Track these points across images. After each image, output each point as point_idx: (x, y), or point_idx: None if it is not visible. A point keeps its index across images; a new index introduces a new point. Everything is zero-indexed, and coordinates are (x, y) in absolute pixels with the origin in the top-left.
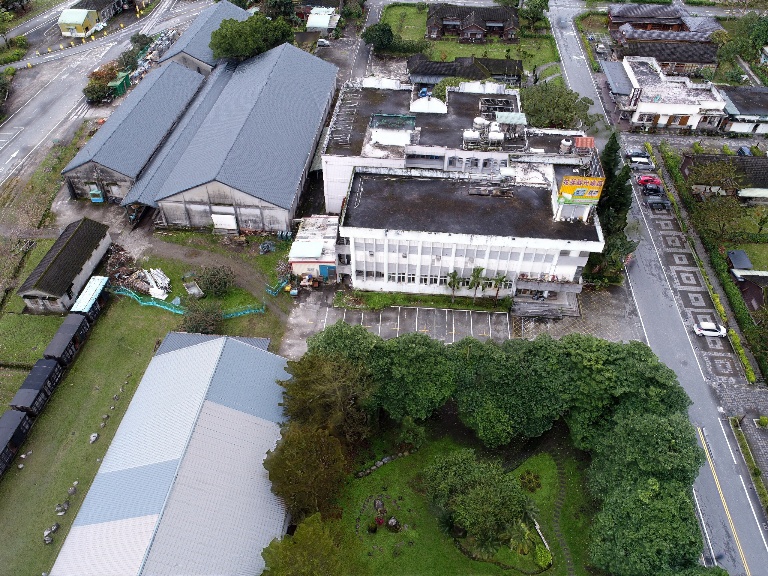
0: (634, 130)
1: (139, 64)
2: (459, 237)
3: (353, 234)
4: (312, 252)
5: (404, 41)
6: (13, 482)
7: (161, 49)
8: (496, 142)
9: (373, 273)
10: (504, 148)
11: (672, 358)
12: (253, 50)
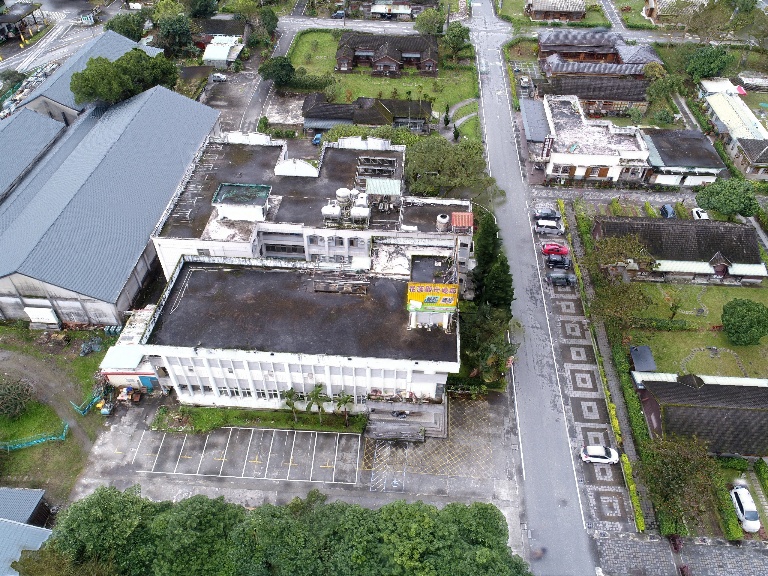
0: (548, 183)
1: (4, 106)
2: (284, 356)
3: (157, 352)
4: (128, 361)
5: (305, 77)
6: None
7: (33, 87)
8: (360, 219)
9: (200, 387)
10: (374, 223)
11: (549, 496)
12: (125, 92)
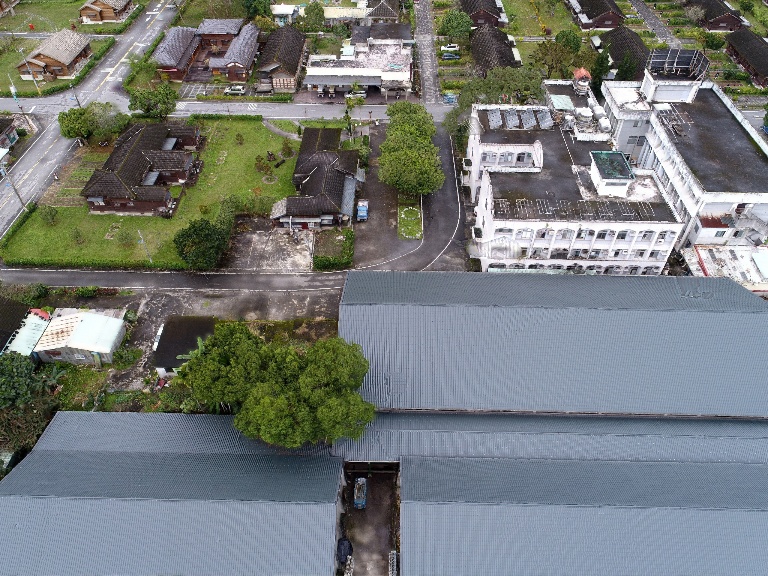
0: None
1: None
2: None
3: None
4: None
5: (226, 218)
6: None
7: None
8: None
9: None
10: None
11: None
12: None
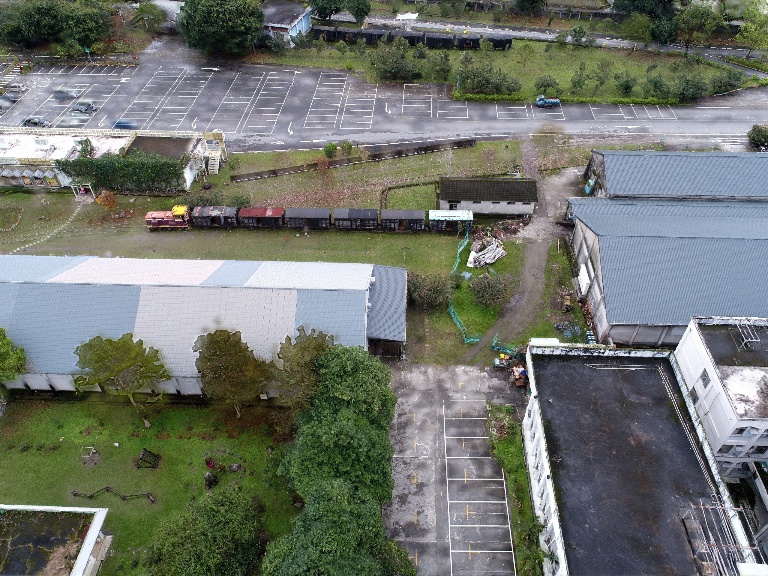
0: None
1: None
2: None
3: None
4: None
5: None
6: (287, 236)
7: None
8: None
9: None
10: None
11: None
12: None
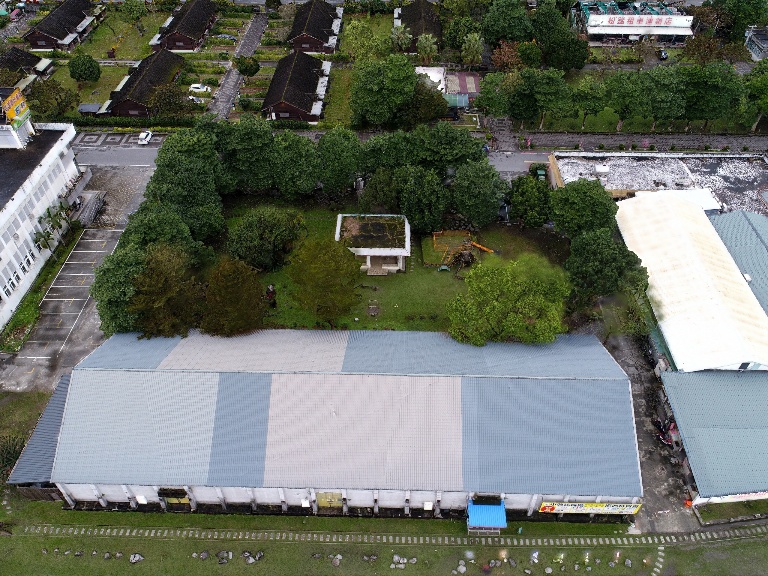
0: None
1: None
2: (17, 196)
3: None
4: None
5: None
6: None
7: None
8: None
9: None
10: None
11: None
12: None
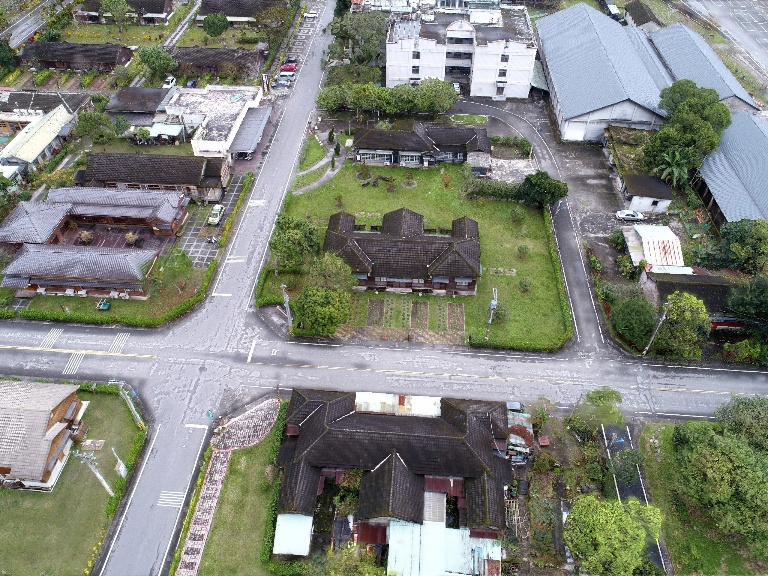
0: None
1: None
2: None
3: None
4: None
5: (504, 181)
6: None
7: None
8: None
9: None
10: None
11: None
12: None
